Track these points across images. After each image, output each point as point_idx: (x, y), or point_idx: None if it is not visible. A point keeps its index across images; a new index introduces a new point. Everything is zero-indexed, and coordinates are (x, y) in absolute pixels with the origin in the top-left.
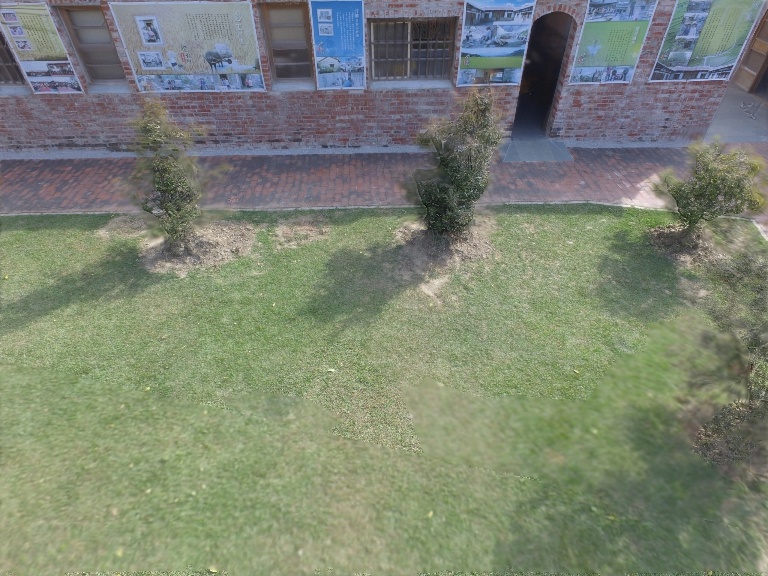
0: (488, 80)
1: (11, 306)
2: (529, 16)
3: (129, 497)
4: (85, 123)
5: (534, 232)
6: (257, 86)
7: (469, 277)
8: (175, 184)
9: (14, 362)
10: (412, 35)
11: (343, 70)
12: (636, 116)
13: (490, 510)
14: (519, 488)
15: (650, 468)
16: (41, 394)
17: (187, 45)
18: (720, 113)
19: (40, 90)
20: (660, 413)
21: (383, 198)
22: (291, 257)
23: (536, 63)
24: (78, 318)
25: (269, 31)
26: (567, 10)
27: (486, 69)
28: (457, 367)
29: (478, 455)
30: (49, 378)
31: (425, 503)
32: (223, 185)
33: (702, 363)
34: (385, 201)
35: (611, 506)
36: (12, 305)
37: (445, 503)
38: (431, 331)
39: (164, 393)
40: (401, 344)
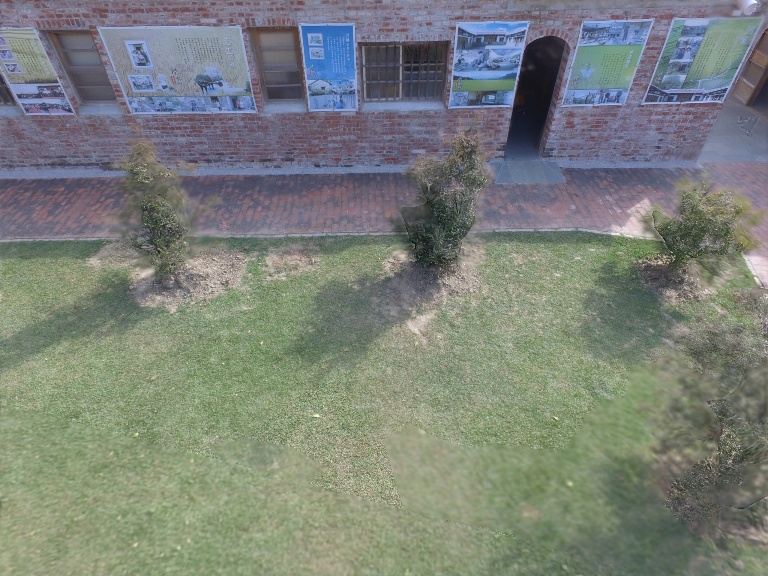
0: (480, 102)
1: (4, 343)
2: (521, 40)
3: (116, 551)
4: (77, 143)
5: (522, 263)
6: (248, 108)
7: (455, 313)
8: (164, 222)
9: (6, 405)
10: (404, 58)
11: (334, 92)
12: (629, 137)
13: (464, 568)
14: (493, 545)
15: (622, 524)
16: (32, 440)
17: (177, 68)
18: (716, 129)
19: (31, 111)
20: (635, 464)
21: (373, 224)
22: (280, 290)
23: (529, 85)
24: (69, 356)
25: (260, 54)
26: (560, 34)
27: (478, 91)
28: (439, 413)
29: (455, 509)
30: (40, 422)
31: (402, 560)
32: (215, 209)
33: (680, 409)
34: (375, 227)
35: (581, 564)
36: (5, 342)
37: (421, 560)
38: (415, 373)
39: (152, 439)
40: (385, 387)
